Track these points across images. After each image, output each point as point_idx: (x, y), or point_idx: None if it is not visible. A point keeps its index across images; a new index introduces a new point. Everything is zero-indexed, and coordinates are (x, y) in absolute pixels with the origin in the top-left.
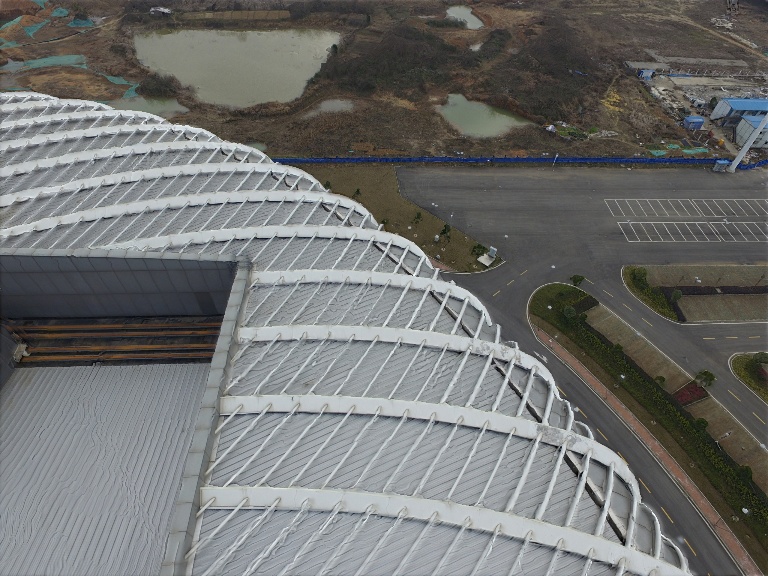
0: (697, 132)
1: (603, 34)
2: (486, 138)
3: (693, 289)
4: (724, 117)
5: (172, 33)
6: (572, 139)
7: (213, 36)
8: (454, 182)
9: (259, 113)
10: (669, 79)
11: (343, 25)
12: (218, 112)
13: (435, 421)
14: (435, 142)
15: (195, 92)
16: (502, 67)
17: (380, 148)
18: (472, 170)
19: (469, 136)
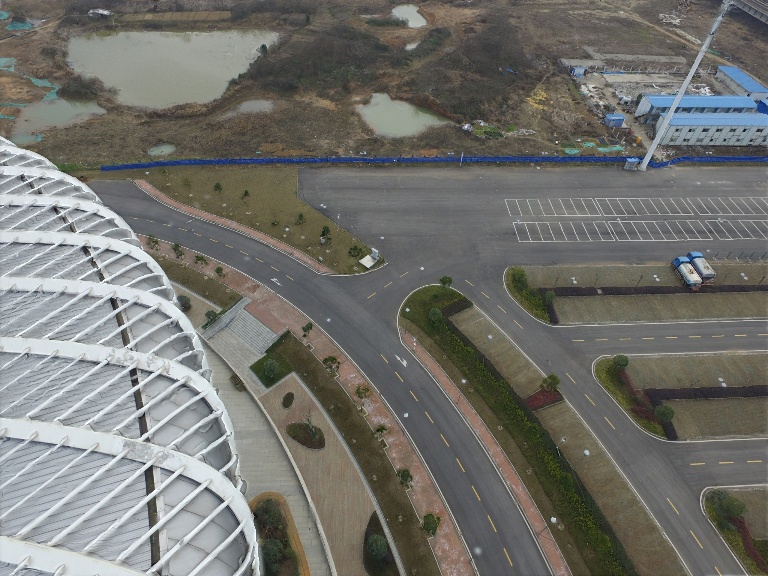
0: (617, 130)
1: (544, 31)
2: (399, 138)
3: (572, 290)
4: (646, 114)
5: (111, 35)
6: (487, 138)
7: (156, 37)
8: (355, 183)
9: (175, 114)
10: (602, 76)
11: (283, 25)
12: (134, 114)
13: (6, 437)
14: (346, 142)
15: (115, 94)
16: (432, 66)
17: (288, 149)
18: (377, 170)
19: (383, 136)
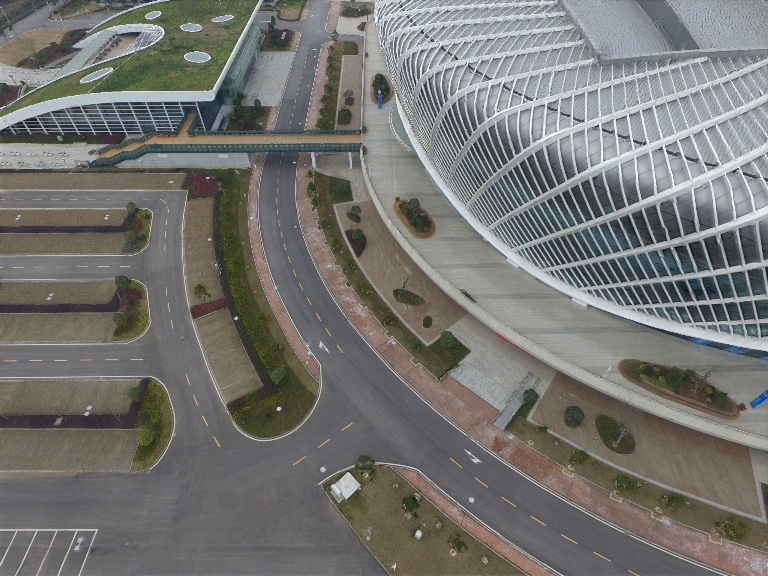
0: None
1: None
2: None
3: (93, 420)
4: None
5: None
6: None
7: None
8: None
9: None
10: None
11: None
12: None
13: None
14: None
15: None
16: None
17: None
18: None
19: None
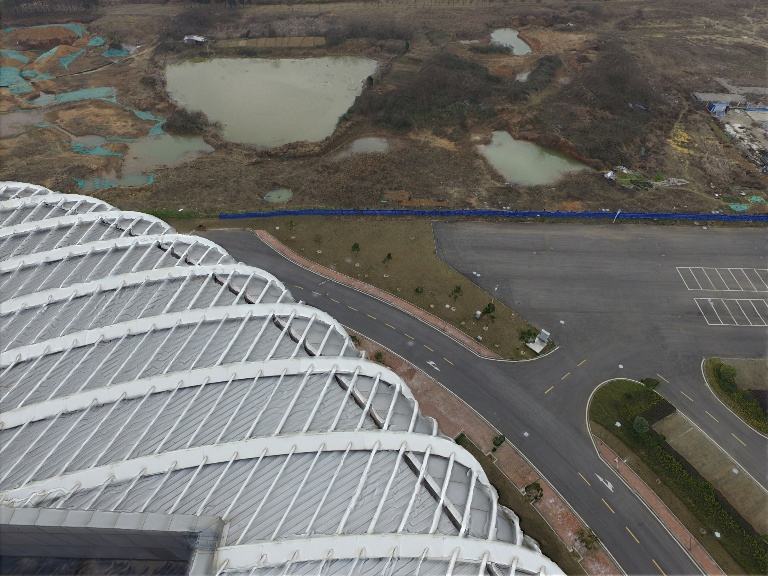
0: None
1: (666, 60)
2: (535, 186)
3: None
4: None
5: (205, 62)
6: (635, 189)
7: (246, 63)
8: (498, 241)
9: (287, 154)
10: (745, 114)
11: (380, 52)
12: (244, 152)
13: None
14: (477, 191)
15: (222, 129)
16: (553, 100)
17: (416, 198)
18: (519, 226)
19: (516, 183)
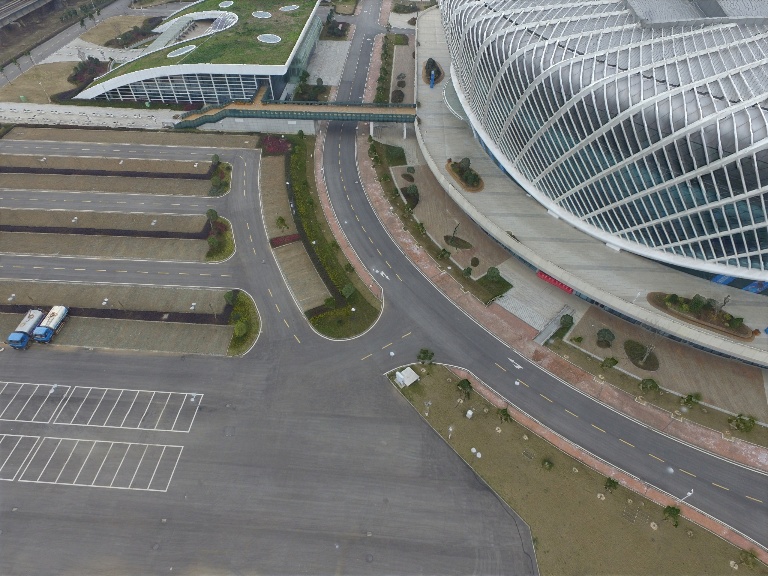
0: None
1: None
2: None
3: (194, 316)
4: None
5: None
6: None
7: None
8: (425, 569)
9: None
10: None
11: None
12: None
13: None
14: None
15: None
16: None
17: None
18: None
19: None
